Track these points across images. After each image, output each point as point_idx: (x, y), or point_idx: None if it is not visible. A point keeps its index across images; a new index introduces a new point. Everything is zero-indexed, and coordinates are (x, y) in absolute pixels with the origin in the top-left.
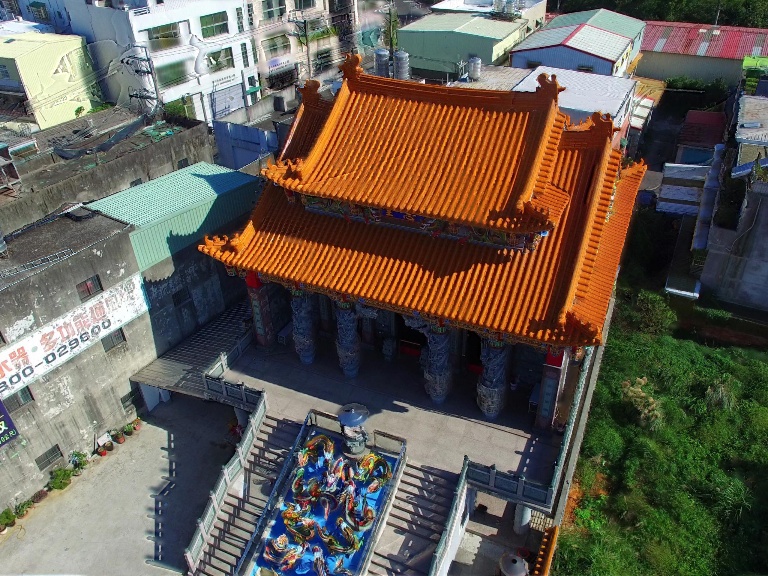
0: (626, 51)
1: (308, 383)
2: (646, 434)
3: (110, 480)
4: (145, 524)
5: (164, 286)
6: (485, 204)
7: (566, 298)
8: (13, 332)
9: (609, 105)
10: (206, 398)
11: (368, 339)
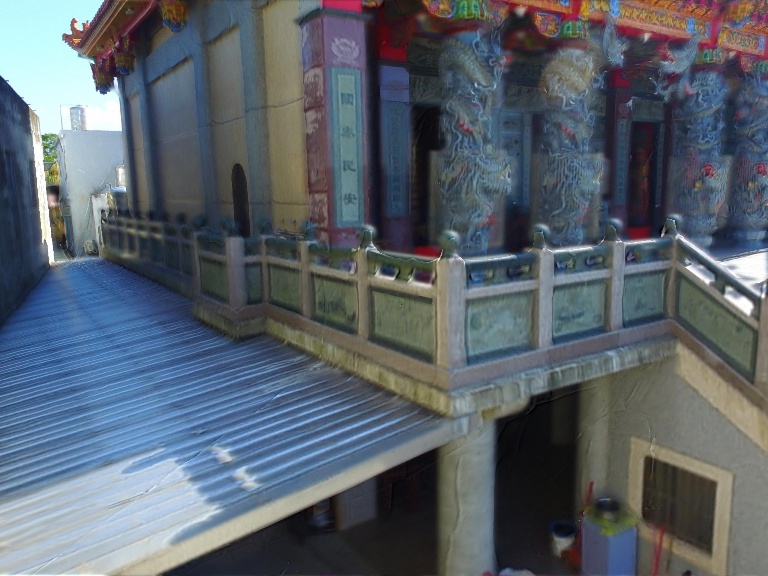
0: None
1: None
2: None
3: None
4: None
5: None
6: None
7: None
8: None
9: None
10: (466, 428)
11: (492, 234)
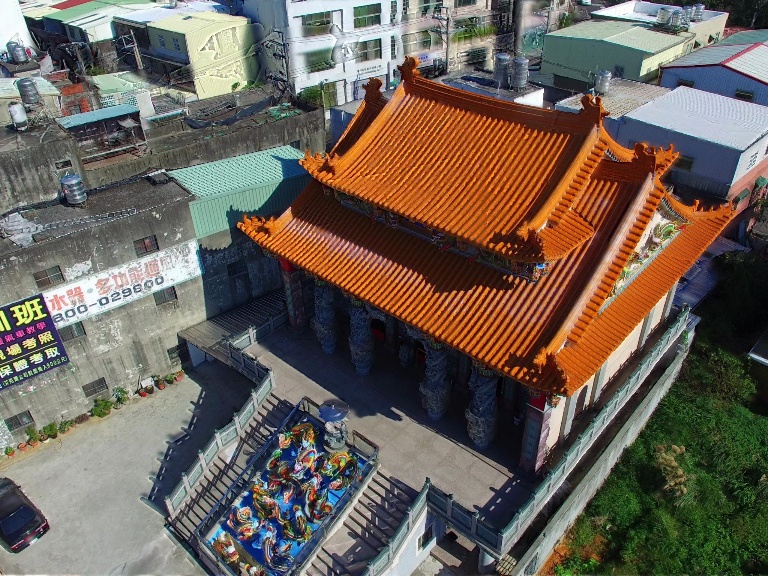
0: None
1: (320, 371)
2: (668, 508)
3: (140, 419)
4: (153, 465)
5: (220, 255)
6: (493, 225)
7: (552, 338)
8: (72, 272)
9: (742, 137)
10: (229, 365)
11: (390, 341)
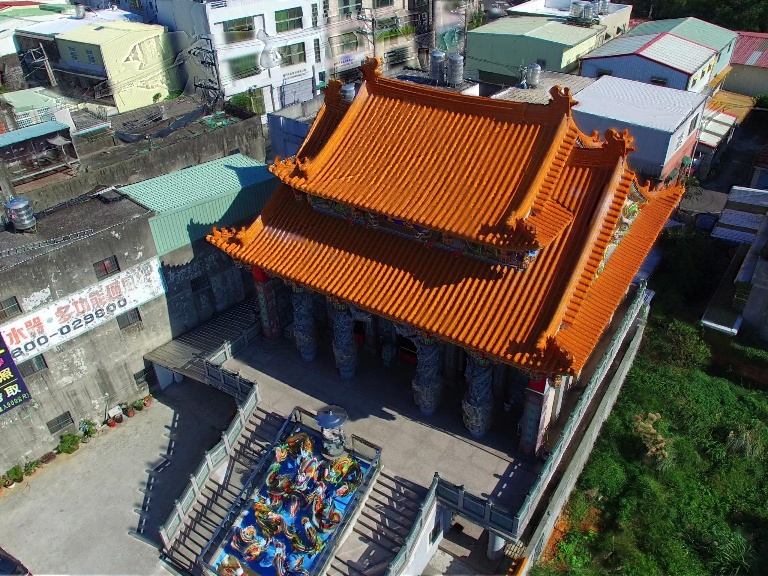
0: (708, 63)
1: (304, 380)
2: (652, 473)
3: (113, 451)
4: (135, 497)
5: (182, 271)
6: (479, 217)
7: (550, 322)
8: (30, 302)
9: (669, 120)
10: (206, 383)
11: (370, 342)
